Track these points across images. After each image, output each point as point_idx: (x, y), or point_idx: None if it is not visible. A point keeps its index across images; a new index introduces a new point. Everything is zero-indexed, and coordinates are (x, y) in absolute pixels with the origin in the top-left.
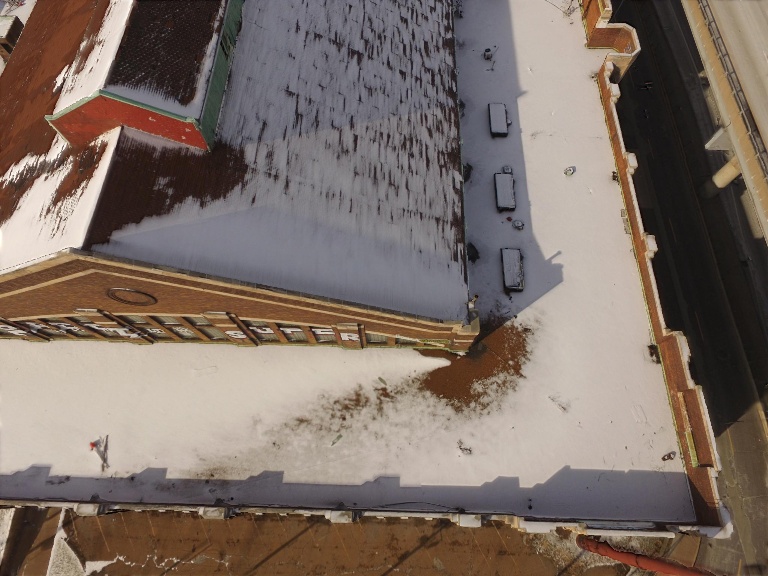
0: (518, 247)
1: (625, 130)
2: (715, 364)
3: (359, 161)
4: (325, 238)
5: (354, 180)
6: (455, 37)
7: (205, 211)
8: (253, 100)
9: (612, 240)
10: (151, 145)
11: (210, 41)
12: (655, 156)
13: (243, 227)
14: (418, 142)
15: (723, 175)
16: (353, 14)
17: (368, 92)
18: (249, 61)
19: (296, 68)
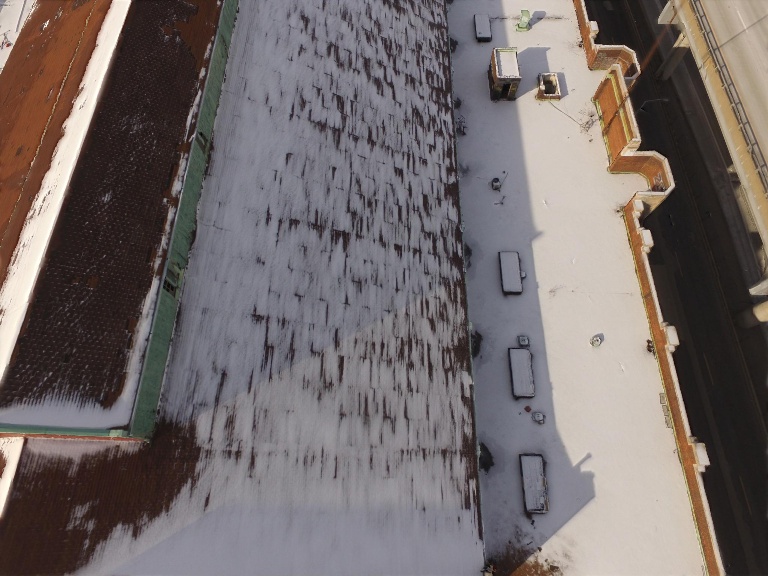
0: (539, 448)
1: None
2: (767, 547)
3: (346, 395)
4: (302, 530)
5: (340, 426)
6: (459, 179)
7: (139, 542)
8: (209, 343)
9: (651, 437)
10: (66, 457)
11: (148, 292)
12: (684, 274)
13: (192, 551)
14: (418, 343)
15: (767, 311)
16: (337, 179)
17: (356, 287)
18: (205, 284)
19: (266, 277)
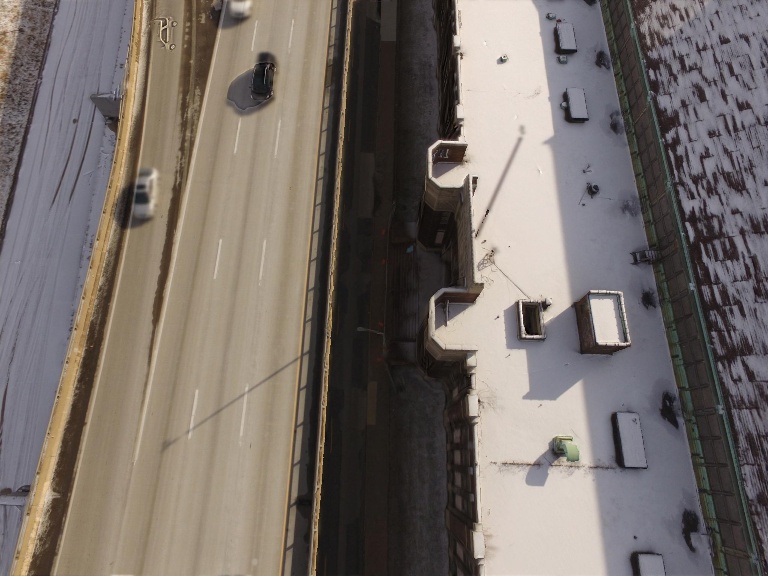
0: (551, 2)
1: (366, 242)
2: (352, 32)
3: None
4: None
5: None
6: (661, 140)
7: None
8: None
9: (473, 6)
10: None
11: None
12: (342, 207)
13: None
14: None
15: None
16: None
17: None
18: None
19: None
